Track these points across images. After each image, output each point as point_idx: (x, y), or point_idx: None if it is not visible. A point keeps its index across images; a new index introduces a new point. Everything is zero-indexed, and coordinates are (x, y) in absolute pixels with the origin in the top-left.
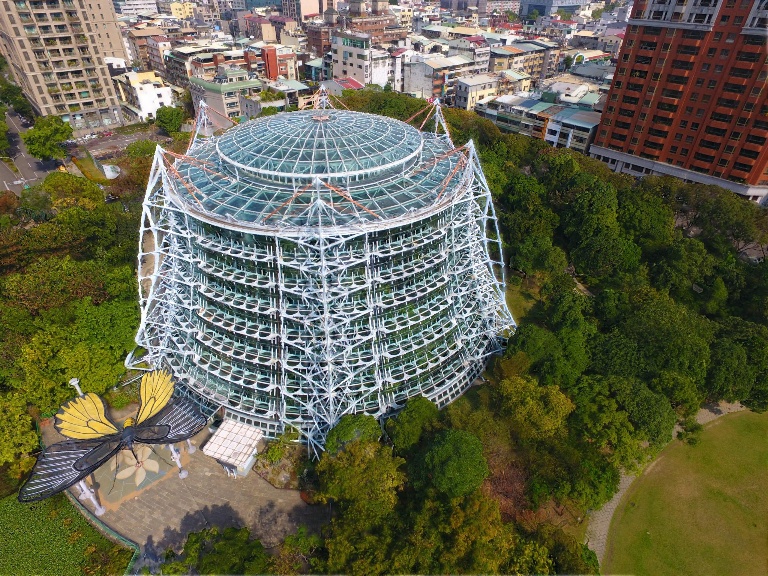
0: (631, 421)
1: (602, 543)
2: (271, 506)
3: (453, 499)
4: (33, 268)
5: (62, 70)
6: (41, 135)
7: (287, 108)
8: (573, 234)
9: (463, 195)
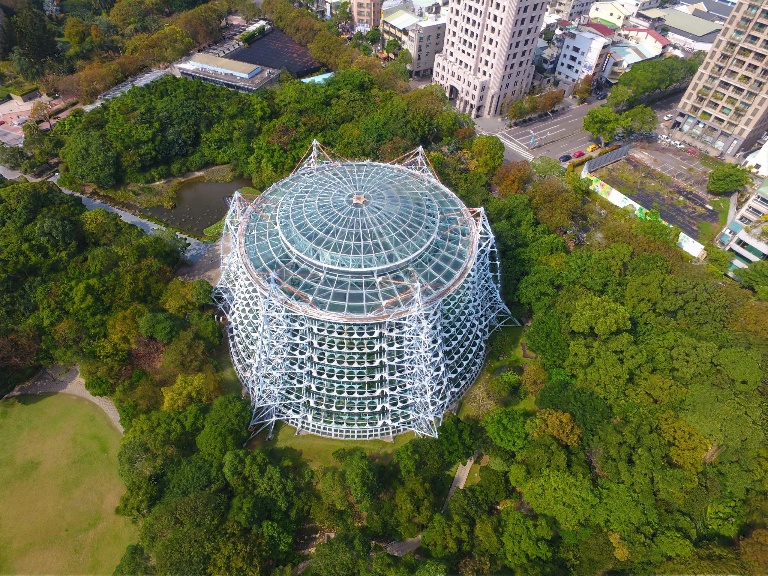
0: (134, 438)
1: (117, 424)
2: (211, 281)
3: (138, 315)
4: (370, 160)
5: (728, 80)
6: (599, 116)
7: (761, 260)
8: (400, 558)
9: None
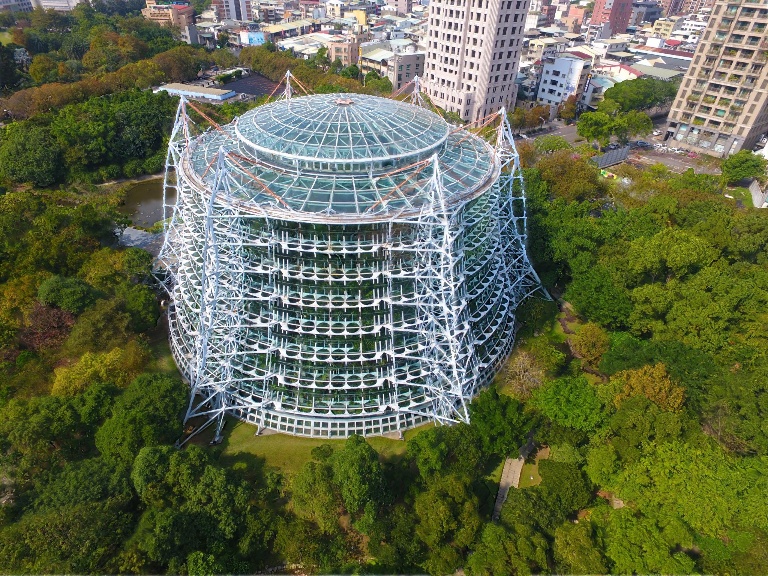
0: None
1: None
2: (156, 267)
3: (39, 280)
4: None
5: (718, 82)
6: (593, 118)
7: None
8: None
9: (217, 201)
